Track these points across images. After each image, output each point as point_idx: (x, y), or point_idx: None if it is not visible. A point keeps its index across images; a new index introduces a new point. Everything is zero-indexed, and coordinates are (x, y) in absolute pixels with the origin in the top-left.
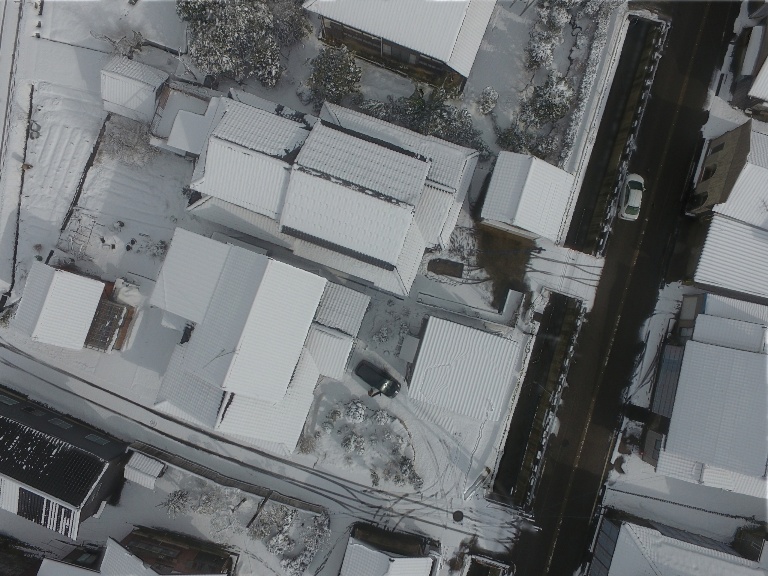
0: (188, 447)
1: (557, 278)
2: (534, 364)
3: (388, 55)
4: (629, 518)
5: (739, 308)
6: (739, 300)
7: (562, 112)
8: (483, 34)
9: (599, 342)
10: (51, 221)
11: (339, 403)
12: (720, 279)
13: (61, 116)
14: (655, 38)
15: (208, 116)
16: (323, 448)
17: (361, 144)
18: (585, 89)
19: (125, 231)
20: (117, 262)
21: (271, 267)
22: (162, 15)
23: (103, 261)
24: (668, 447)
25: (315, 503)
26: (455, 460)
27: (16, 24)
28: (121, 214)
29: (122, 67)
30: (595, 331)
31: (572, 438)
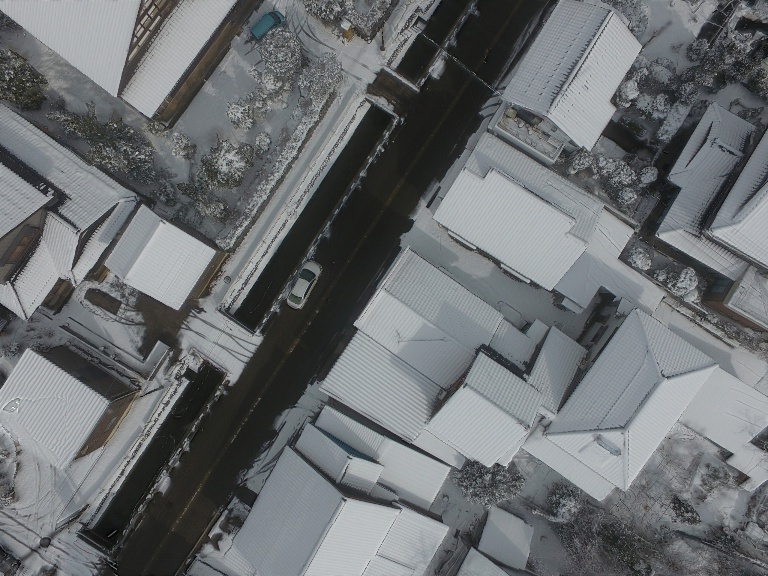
0: None
1: (209, 343)
2: (177, 418)
3: None
4: None
5: (352, 429)
6: (355, 421)
7: None
8: (179, 77)
9: (231, 418)
10: None
11: None
12: (344, 394)
13: None
14: (387, 129)
15: None
16: None
17: None
18: (279, 163)
19: None
20: None
21: None
22: None
23: None
24: (235, 542)
25: None
26: (58, 489)
27: None
28: None
29: None
30: (231, 406)
31: (177, 502)
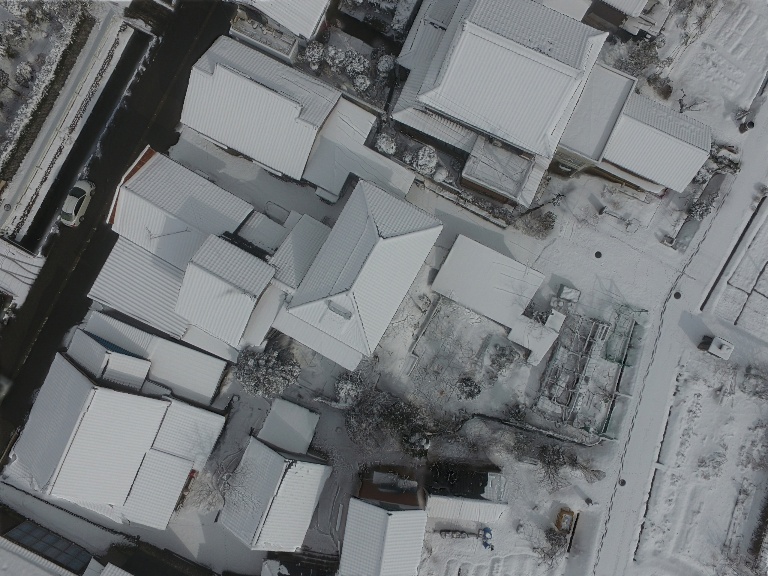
0: None
1: None
2: None
3: None
4: (5, 513)
5: (121, 330)
6: (123, 323)
7: None
8: None
9: (21, 339)
10: None
11: None
12: (111, 299)
13: None
14: None
15: None
16: None
17: None
18: (36, 86)
19: None
20: None
21: None
22: None
23: None
24: (16, 451)
25: None
26: None
27: None
28: None
29: None
30: (19, 328)
31: None
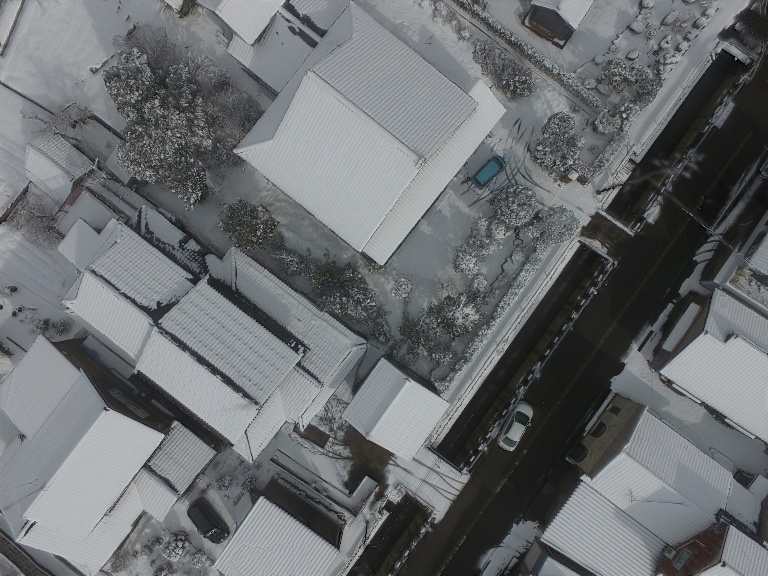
0: None
1: (416, 480)
2: (372, 548)
3: None
4: None
5: None
6: (577, 574)
7: None
8: (412, 227)
9: (436, 555)
10: None
11: (166, 530)
12: (566, 546)
13: None
14: (598, 271)
15: (102, 236)
16: (137, 568)
17: (238, 316)
18: (501, 309)
19: (16, 296)
20: None
21: (105, 417)
22: None
23: None
24: None
25: None
26: None
27: None
28: (18, 278)
29: (50, 145)
30: (436, 543)
31: None
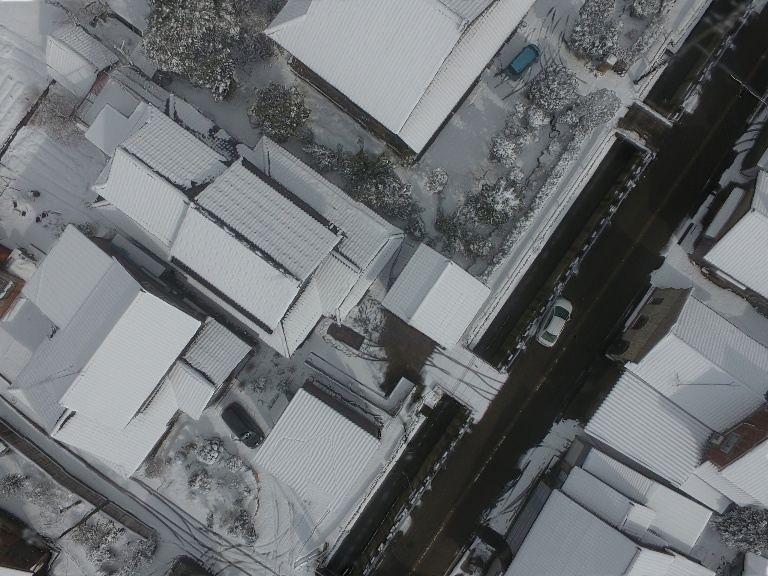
0: (41, 433)
1: (454, 380)
2: (409, 455)
3: (352, 102)
4: None
5: (619, 472)
6: (622, 464)
7: (503, 219)
8: (448, 113)
9: (476, 456)
10: None
11: (199, 437)
12: (610, 437)
13: (8, 65)
14: (636, 164)
15: (131, 120)
16: (171, 475)
17: (275, 197)
18: (539, 199)
19: (39, 202)
20: (23, 230)
21: (141, 299)
22: None
23: (10, 225)
24: None
25: (149, 525)
26: (297, 526)
27: None
28: (40, 183)
29: (72, 37)
30: (475, 444)
31: (418, 541)
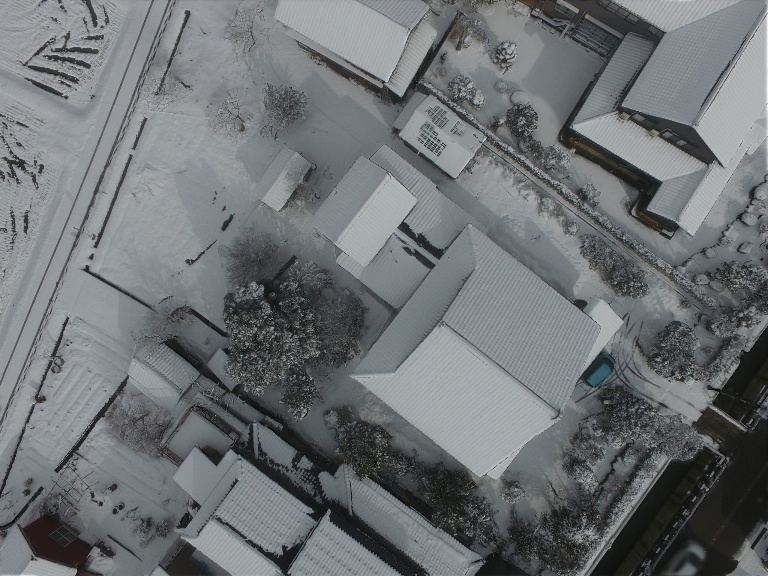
0: None
1: None
2: None
3: None
4: None
5: None
6: None
7: None
8: None
9: None
10: (48, 459)
11: None
12: None
13: (87, 358)
14: (709, 465)
15: (220, 469)
16: None
17: (362, 555)
18: (616, 516)
19: (116, 493)
20: (100, 520)
21: None
22: (214, 288)
23: (87, 515)
24: None
25: None
26: None
27: (69, 251)
28: (117, 474)
29: (156, 356)
30: None
31: None
